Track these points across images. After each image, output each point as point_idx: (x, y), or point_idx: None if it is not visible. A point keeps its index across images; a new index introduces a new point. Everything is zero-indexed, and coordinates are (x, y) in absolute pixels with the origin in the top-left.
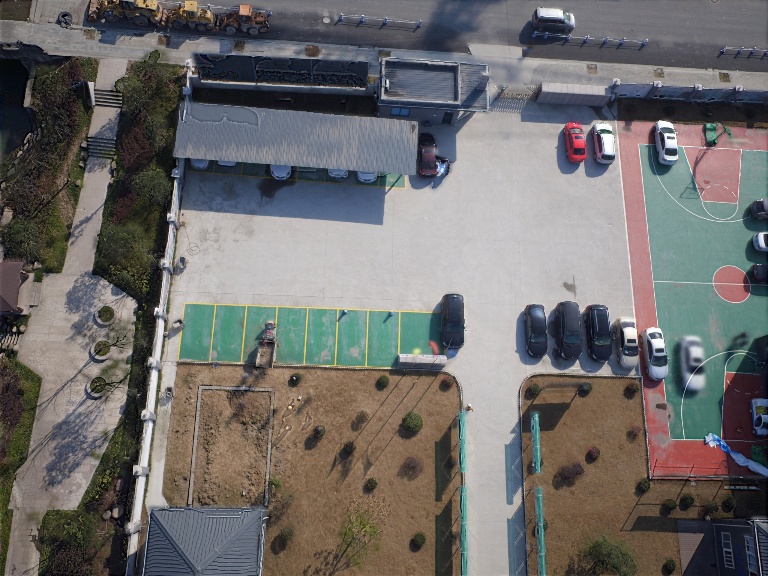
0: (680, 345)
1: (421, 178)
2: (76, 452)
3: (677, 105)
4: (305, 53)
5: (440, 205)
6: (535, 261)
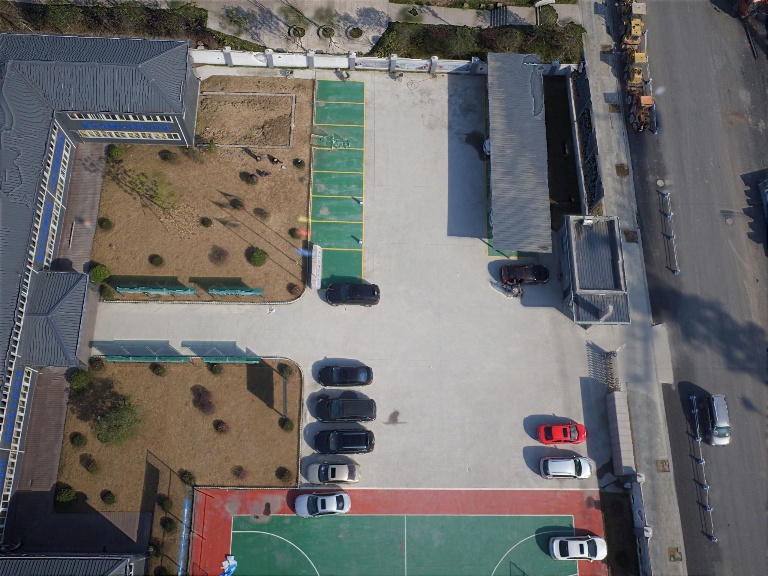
0: (334, 539)
1: (500, 270)
2: (249, 24)
3: (633, 572)
4: (619, 164)
5: (473, 289)
6: (421, 382)
